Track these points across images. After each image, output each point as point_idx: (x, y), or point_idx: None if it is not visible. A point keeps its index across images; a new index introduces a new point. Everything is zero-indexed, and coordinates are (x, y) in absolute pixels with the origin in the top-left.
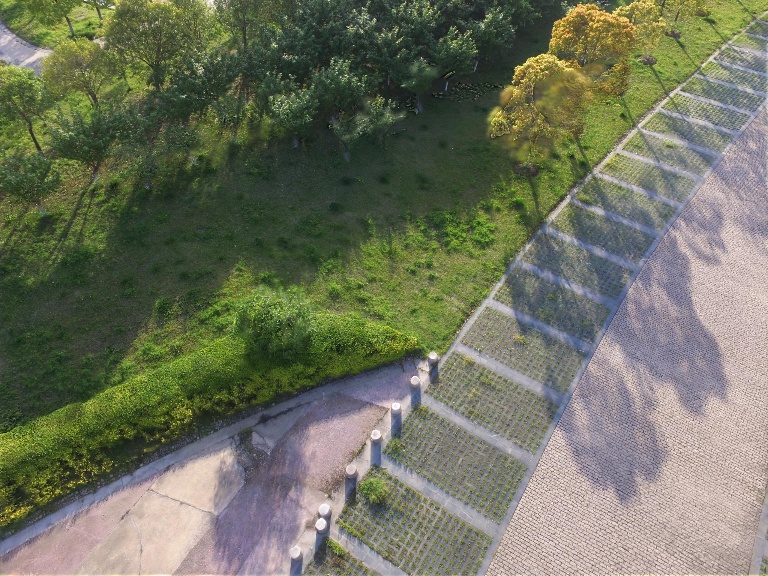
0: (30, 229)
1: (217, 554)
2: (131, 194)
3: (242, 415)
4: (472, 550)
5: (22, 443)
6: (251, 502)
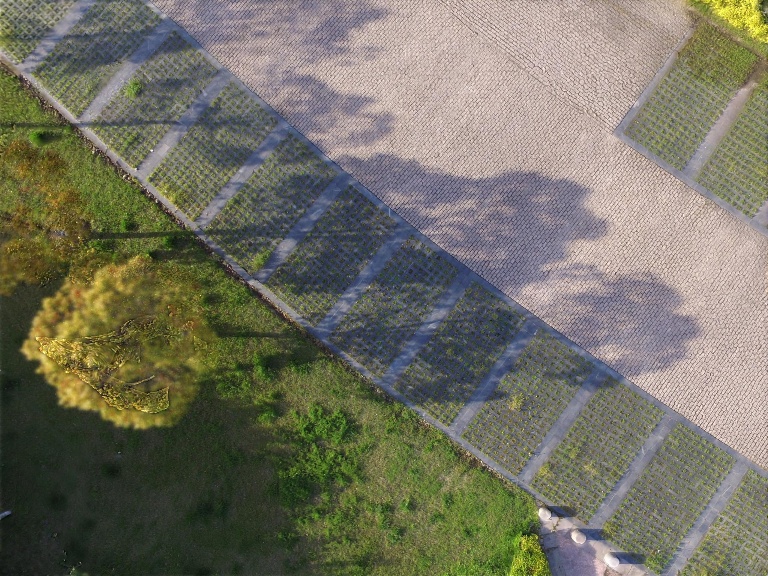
0: None
1: None
2: None
3: None
4: (760, 489)
5: None
6: None
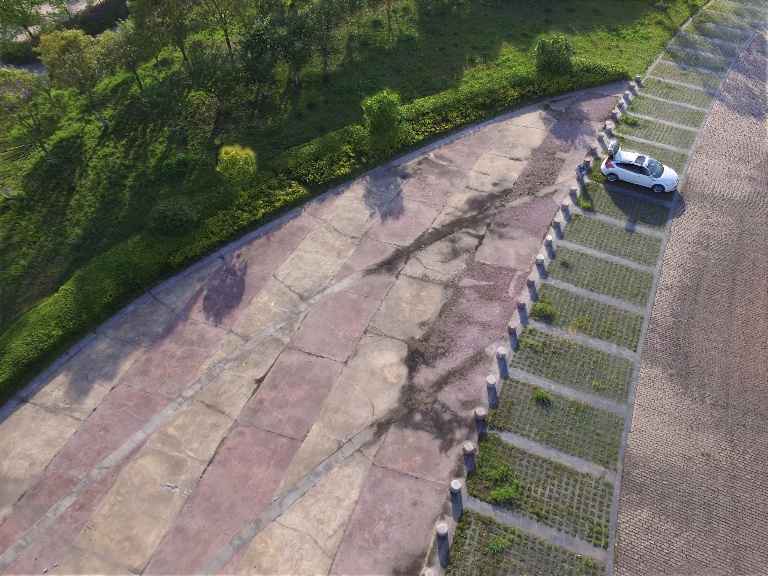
0: (369, 26)
1: (558, 140)
2: (419, 12)
3: (540, 101)
4: (688, 135)
5: (437, 100)
6: (565, 125)
